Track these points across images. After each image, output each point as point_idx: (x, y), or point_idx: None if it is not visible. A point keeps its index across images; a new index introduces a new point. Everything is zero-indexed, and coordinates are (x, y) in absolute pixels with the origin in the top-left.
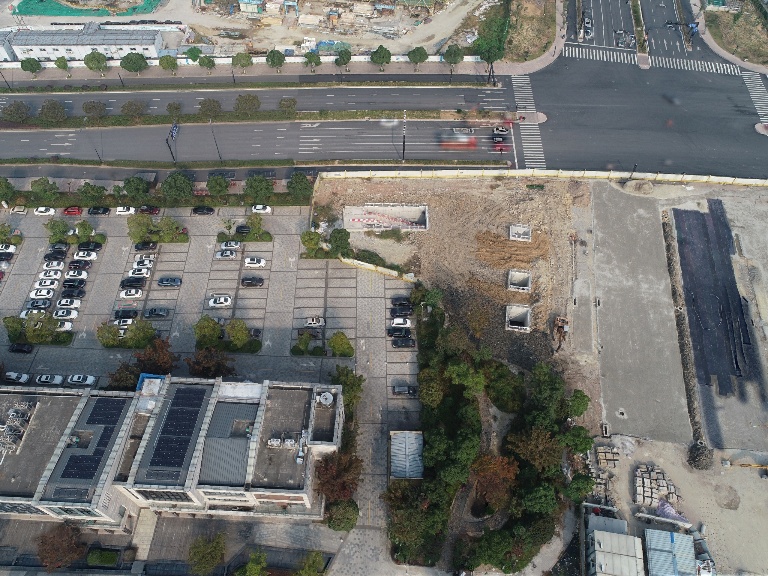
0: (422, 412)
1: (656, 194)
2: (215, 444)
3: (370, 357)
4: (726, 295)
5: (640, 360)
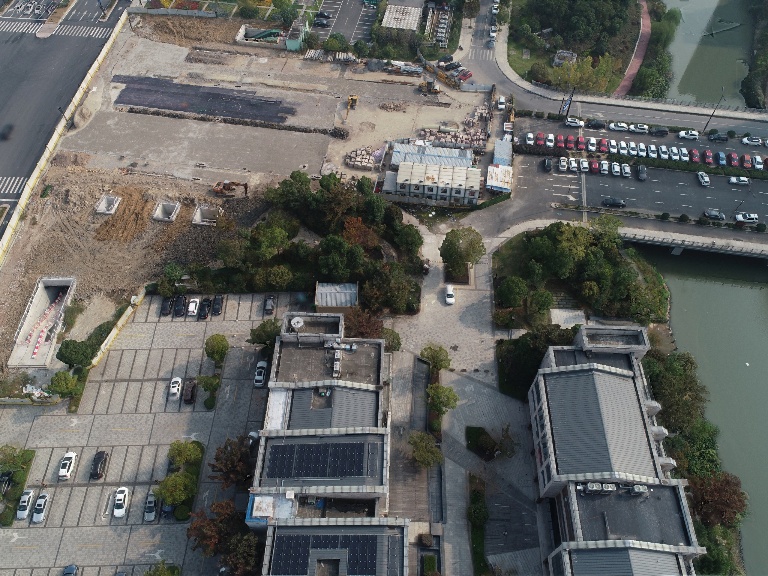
0: (296, 285)
1: (93, 109)
2: (338, 420)
3: (228, 335)
4: (211, 93)
5: (260, 149)
